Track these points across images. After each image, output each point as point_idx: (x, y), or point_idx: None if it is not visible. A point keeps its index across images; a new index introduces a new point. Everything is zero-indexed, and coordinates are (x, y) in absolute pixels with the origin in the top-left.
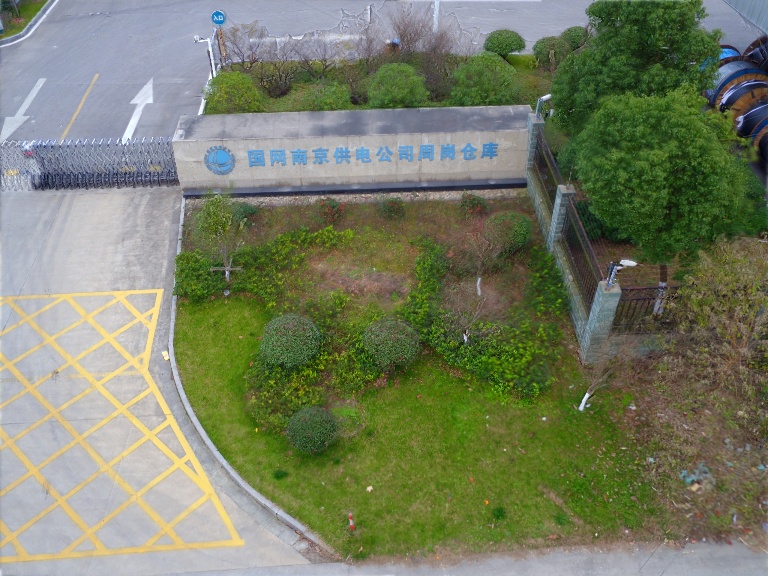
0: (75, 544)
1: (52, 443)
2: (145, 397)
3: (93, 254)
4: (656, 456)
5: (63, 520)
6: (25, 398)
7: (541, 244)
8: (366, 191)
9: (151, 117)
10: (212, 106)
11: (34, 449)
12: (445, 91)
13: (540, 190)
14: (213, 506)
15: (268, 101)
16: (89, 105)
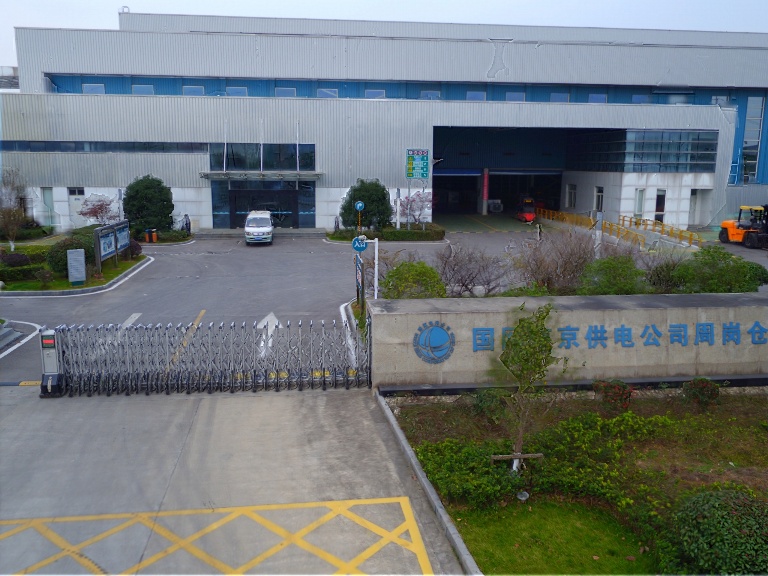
0: None
1: None
2: None
3: (269, 457)
4: None
5: None
6: None
7: None
8: (632, 386)
9: None
10: None
11: None
12: None
13: None
14: None
15: None
16: None
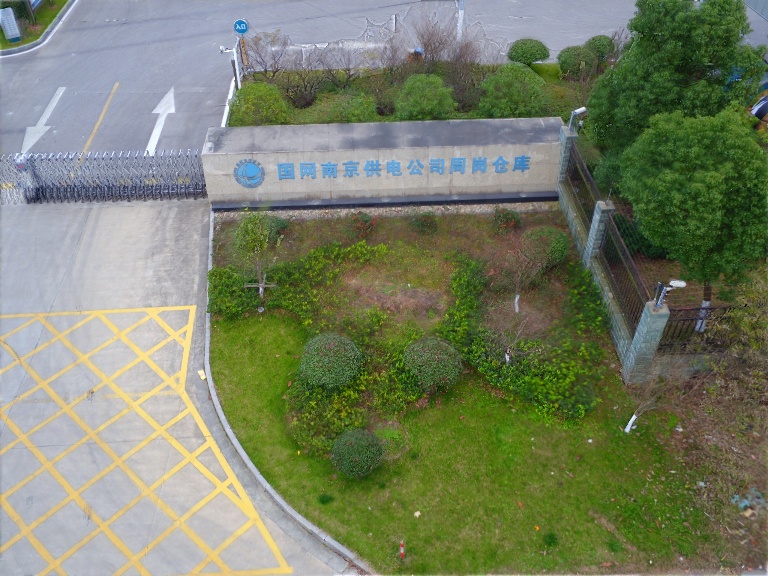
0: (120, 572)
1: (91, 466)
2: (183, 418)
3: (123, 269)
4: (706, 480)
5: (106, 547)
6: (61, 419)
7: (577, 259)
8: (396, 204)
9: (174, 127)
10: (239, 117)
11: (73, 472)
12: (471, 102)
13: (574, 204)
14: (258, 532)
15: (293, 112)
16: (111, 115)
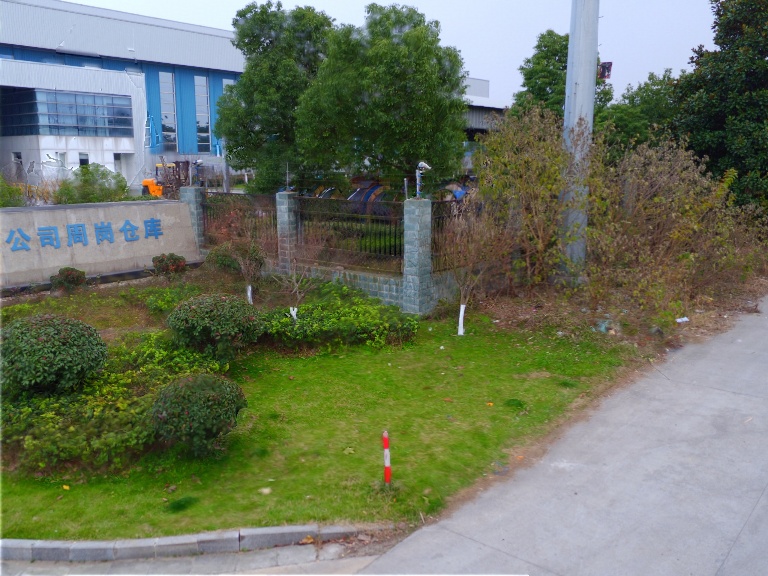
0: None
1: None
2: None
3: None
4: None
5: None
6: None
7: None
8: (2, 293)
9: None
10: None
11: None
12: None
13: None
14: None
15: None
16: None
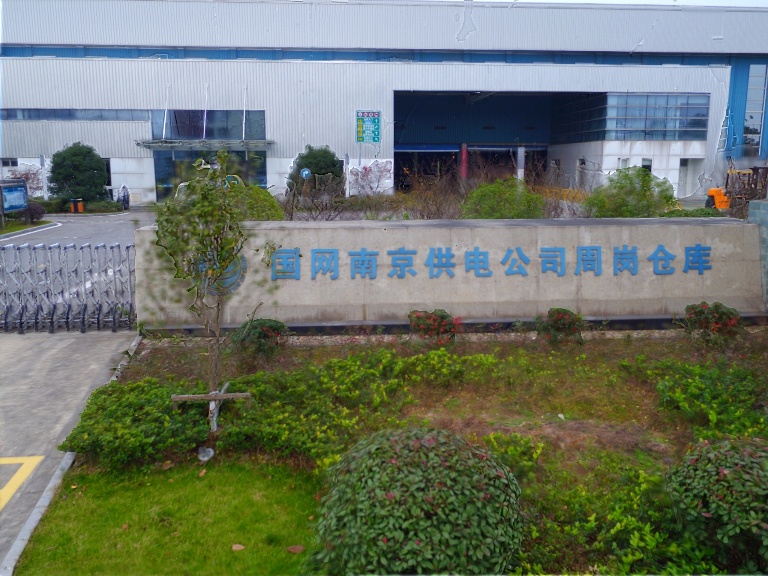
0: None
1: None
2: None
3: None
4: None
5: None
6: None
7: None
8: (485, 327)
9: None
10: None
11: None
12: None
13: None
14: None
15: None
16: None
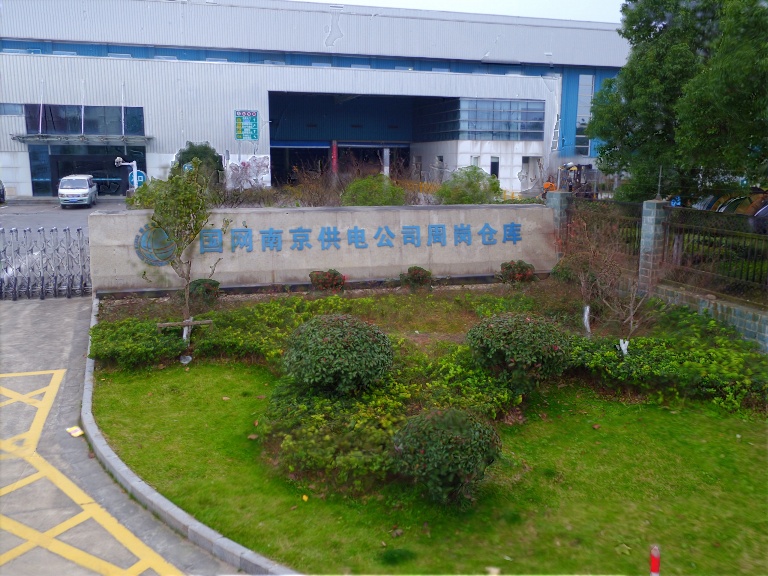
0: None
1: None
2: (28, 485)
3: None
4: None
5: None
6: None
7: None
8: (364, 285)
9: None
10: None
11: None
12: None
13: None
14: None
15: None
16: None
